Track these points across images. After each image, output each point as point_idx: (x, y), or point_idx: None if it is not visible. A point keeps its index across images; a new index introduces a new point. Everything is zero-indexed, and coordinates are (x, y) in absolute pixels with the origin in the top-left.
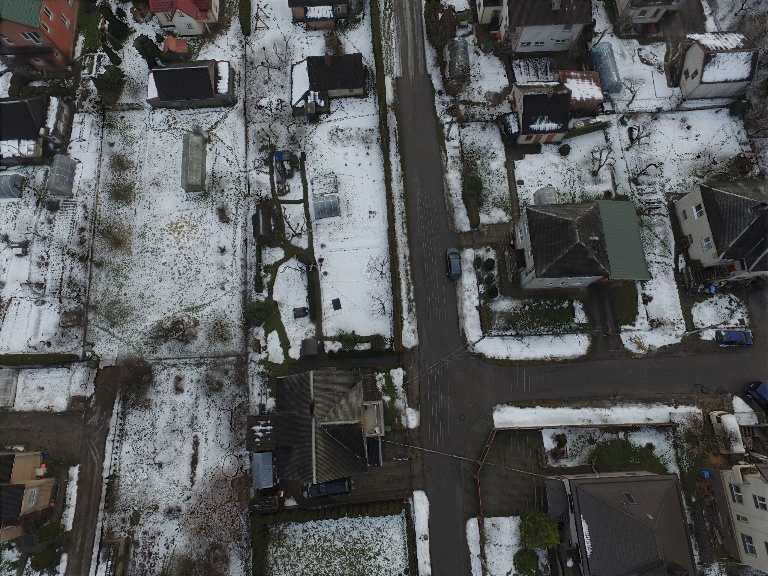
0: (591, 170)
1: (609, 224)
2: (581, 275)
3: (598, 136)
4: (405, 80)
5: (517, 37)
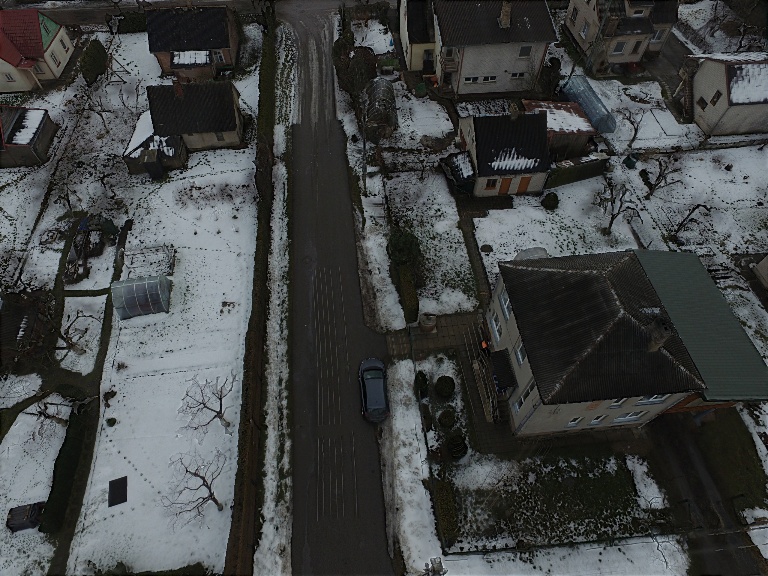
0: (598, 227)
1: (666, 289)
2: (642, 392)
3: (597, 183)
4: (304, 127)
5: (457, 69)
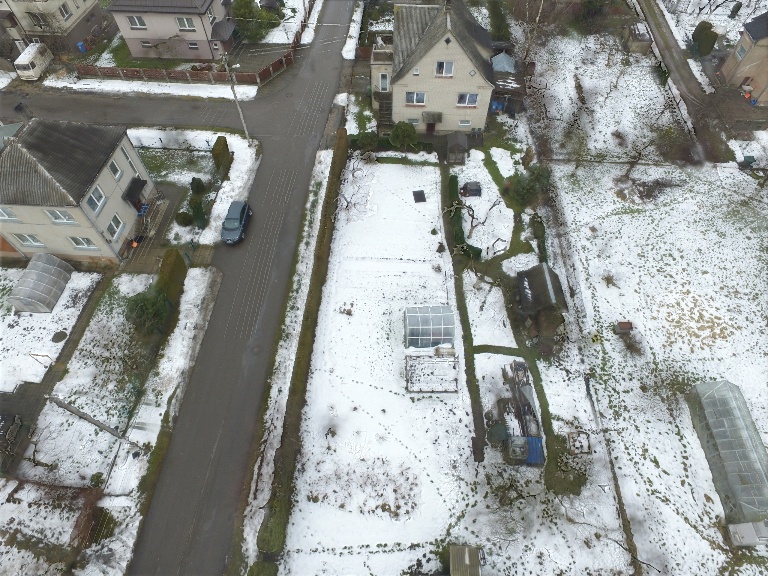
0: None
1: None
2: None
3: None
4: None
5: None
